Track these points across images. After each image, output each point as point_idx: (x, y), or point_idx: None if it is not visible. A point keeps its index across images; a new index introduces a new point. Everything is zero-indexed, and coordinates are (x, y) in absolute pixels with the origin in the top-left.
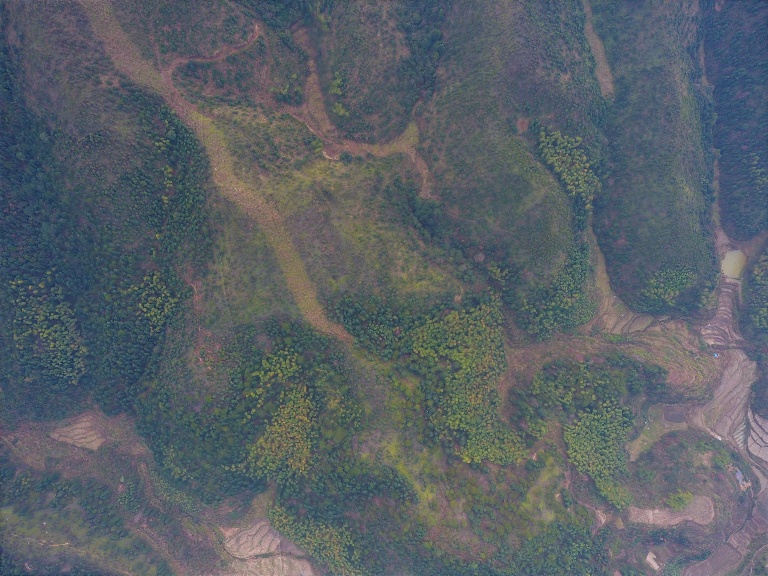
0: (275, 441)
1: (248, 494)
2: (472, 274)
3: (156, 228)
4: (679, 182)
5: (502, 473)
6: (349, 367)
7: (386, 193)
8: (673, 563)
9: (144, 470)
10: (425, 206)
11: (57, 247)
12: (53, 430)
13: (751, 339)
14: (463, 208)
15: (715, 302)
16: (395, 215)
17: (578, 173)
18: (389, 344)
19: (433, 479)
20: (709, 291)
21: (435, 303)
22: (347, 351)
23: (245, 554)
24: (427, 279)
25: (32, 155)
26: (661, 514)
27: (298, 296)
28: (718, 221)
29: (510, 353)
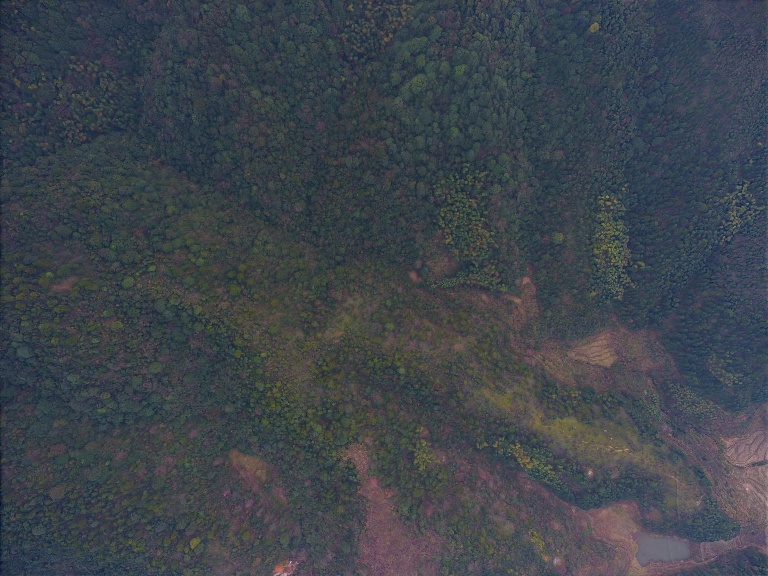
0: None
1: (760, 402)
2: None
3: (760, 136)
4: None
5: None
6: None
7: None
8: None
9: (651, 385)
10: None
11: (651, 161)
12: (571, 349)
13: None
14: None
15: None
16: None
17: None
18: None
19: None
20: None
21: None
22: None
23: (744, 462)
24: None
25: (661, 68)
26: None
27: None
28: None
29: None
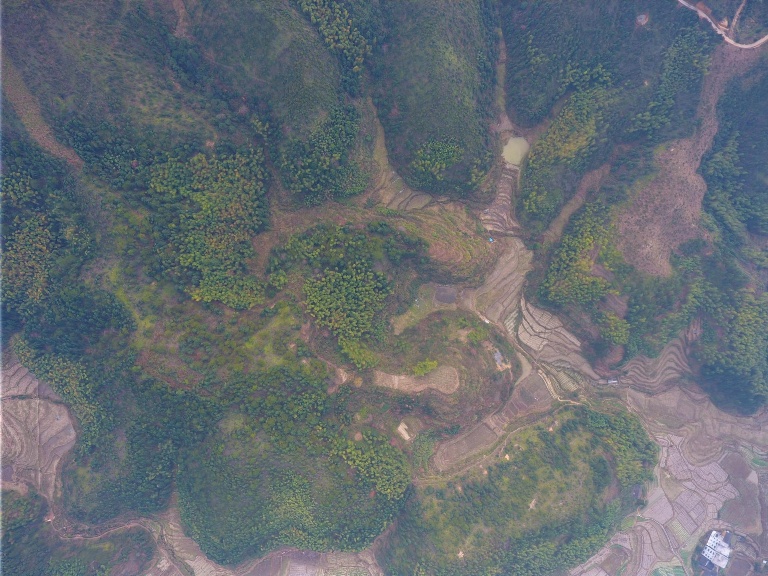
0: (12, 268)
1: (1, 330)
2: (234, 126)
3: None
4: (441, 47)
5: (233, 316)
6: (78, 192)
7: (128, 21)
8: (424, 435)
9: None
10: (180, 46)
11: None
12: None
13: (526, 226)
14: (217, 50)
15: (491, 185)
16: (144, 49)
17: (339, 28)
18: (123, 174)
19: (154, 310)
20: (481, 170)
21: (178, 141)
22: (77, 176)
23: (1, 394)
24: (173, 117)
25: None
26: (406, 380)
27: (20, 109)
28: (503, 106)
29: (278, 215)
